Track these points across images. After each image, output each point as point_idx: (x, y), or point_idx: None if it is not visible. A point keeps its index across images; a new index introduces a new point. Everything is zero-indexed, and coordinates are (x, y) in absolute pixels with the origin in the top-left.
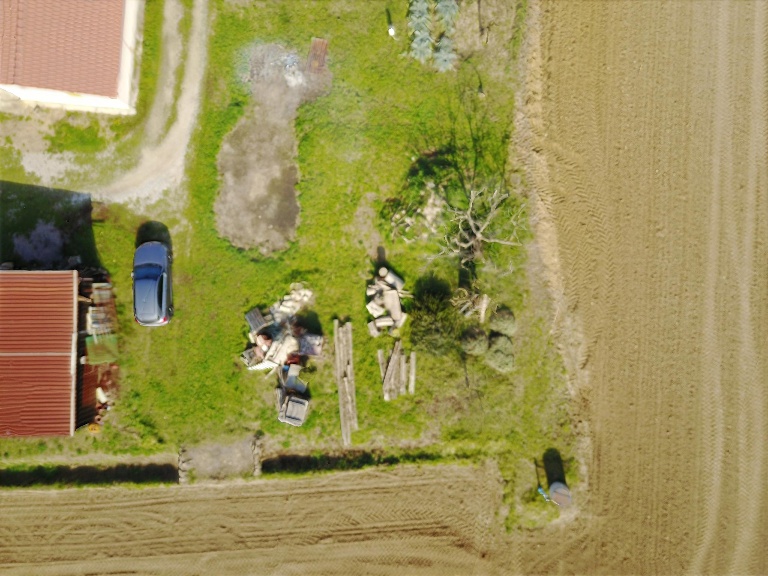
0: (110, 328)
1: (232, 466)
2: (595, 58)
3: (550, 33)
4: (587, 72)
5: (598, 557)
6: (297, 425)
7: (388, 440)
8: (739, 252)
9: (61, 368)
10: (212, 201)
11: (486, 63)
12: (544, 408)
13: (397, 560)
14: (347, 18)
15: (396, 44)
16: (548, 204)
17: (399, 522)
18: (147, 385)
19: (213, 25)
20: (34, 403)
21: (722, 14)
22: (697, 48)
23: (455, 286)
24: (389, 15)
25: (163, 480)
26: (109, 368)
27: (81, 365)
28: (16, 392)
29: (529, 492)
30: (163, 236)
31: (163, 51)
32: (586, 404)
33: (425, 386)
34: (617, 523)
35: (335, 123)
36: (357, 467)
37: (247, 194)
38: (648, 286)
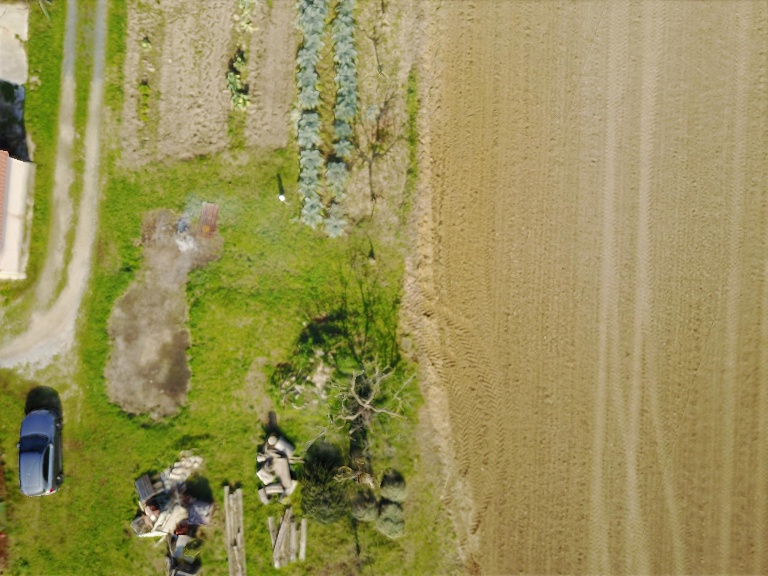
0: None
1: None
2: (484, 224)
3: (441, 197)
4: (476, 238)
5: None
6: None
7: None
8: (626, 419)
9: None
10: (103, 366)
11: (377, 228)
12: (435, 574)
13: None
14: (238, 183)
15: (287, 209)
16: (439, 368)
17: None
18: (36, 553)
19: (104, 189)
20: None
21: (608, 182)
22: (583, 216)
23: (346, 451)
24: (280, 180)
25: None
26: None
27: None
28: None
29: None
30: (53, 401)
31: (54, 215)
32: (477, 569)
33: (316, 553)
34: None
35: (226, 288)
36: None
37: (138, 359)
38: (537, 452)
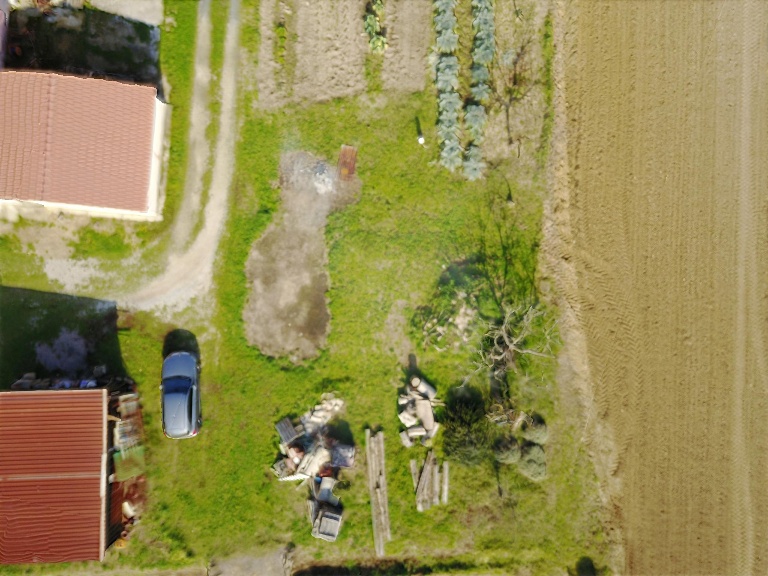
0: (136, 440)
1: None
2: (622, 167)
3: (577, 142)
4: (614, 181)
5: None
6: (330, 540)
7: (420, 550)
8: (765, 360)
9: (90, 491)
10: (241, 309)
11: (515, 171)
12: (576, 516)
13: None
14: (377, 126)
15: (426, 152)
16: (577, 311)
17: None
18: (174, 498)
19: (242, 132)
20: (62, 529)
21: (744, 126)
22: (721, 159)
23: (486, 394)
24: (419, 123)
25: None
26: (135, 482)
27: (109, 484)
28: (43, 518)
29: None
30: (191, 345)
31: (191, 157)
32: (617, 511)
33: (457, 495)
34: None
35: (365, 231)
36: None
37: (277, 302)
38: (677, 393)
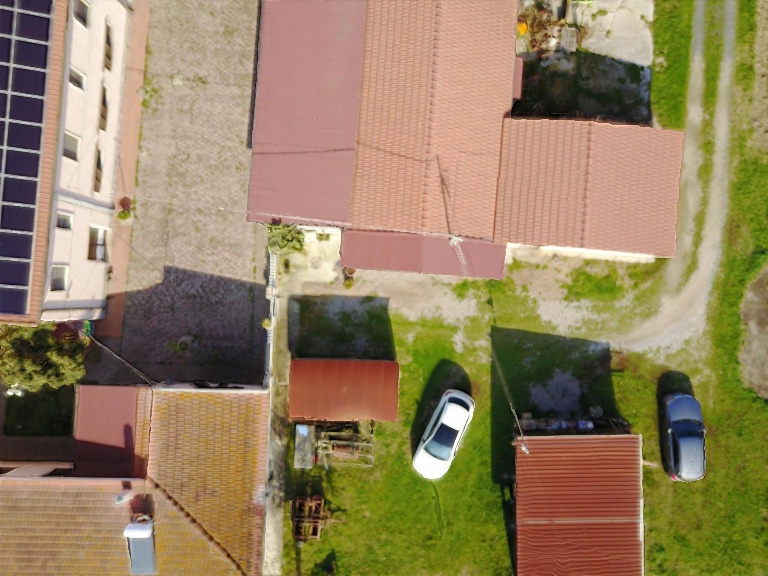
0: None
1: None
2: None
3: None
4: None
5: None
6: None
7: None
8: None
9: (632, 536)
10: (737, 351)
11: None
12: None
13: None
14: None
15: None
16: None
17: None
18: (671, 539)
19: (735, 171)
20: (609, 572)
21: None
22: None
23: None
24: None
25: None
26: None
27: None
28: (592, 561)
29: None
30: (685, 387)
31: (682, 198)
32: None
33: None
34: None
35: None
36: None
37: None
38: None
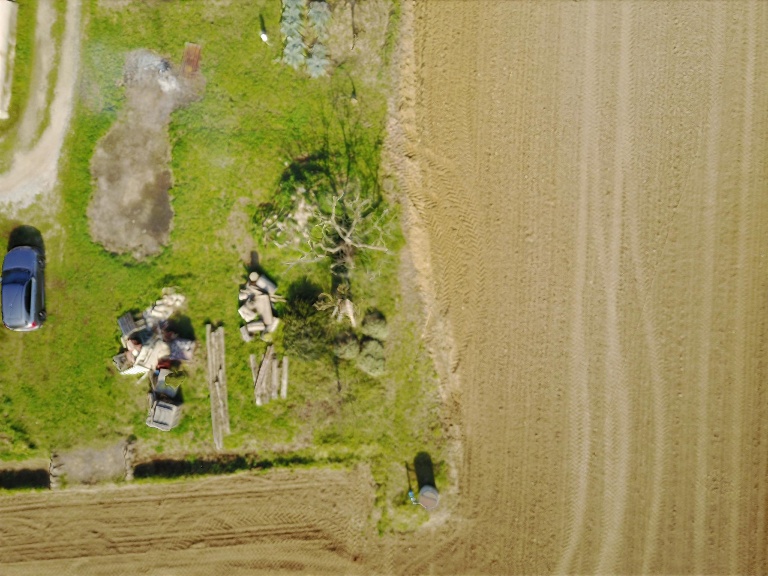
0: None
1: (104, 471)
2: (466, 65)
3: (423, 39)
4: (458, 78)
5: (467, 559)
6: (165, 430)
7: (261, 444)
8: (606, 257)
9: None
10: (85, 205)
11: (359, 69)
12: (416, 412)
13: (269, 564)
14: (221, 23)
15: (270, 49)
16: (421, 209)
17: (272, 526)
18: (19, 390)
19: (86, 29)
20: None
21: (590, 22)
22: (565, 55)
23: (328, 291)
24: (263, 21)
25: (34, 485)
26: None
27: None
28: None
29: (400, 495)
30: (36, 240)
31: (36, 55)
32: (458, 408)
33: (297, 390)
34: (486, 526)
35: (208, 128)
36: (230, 471)
37: (121, 199)
38: (517, 291)
